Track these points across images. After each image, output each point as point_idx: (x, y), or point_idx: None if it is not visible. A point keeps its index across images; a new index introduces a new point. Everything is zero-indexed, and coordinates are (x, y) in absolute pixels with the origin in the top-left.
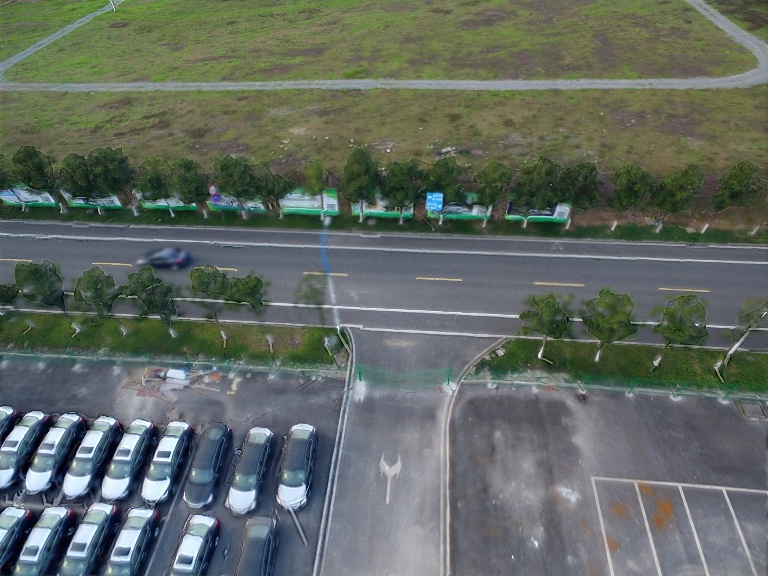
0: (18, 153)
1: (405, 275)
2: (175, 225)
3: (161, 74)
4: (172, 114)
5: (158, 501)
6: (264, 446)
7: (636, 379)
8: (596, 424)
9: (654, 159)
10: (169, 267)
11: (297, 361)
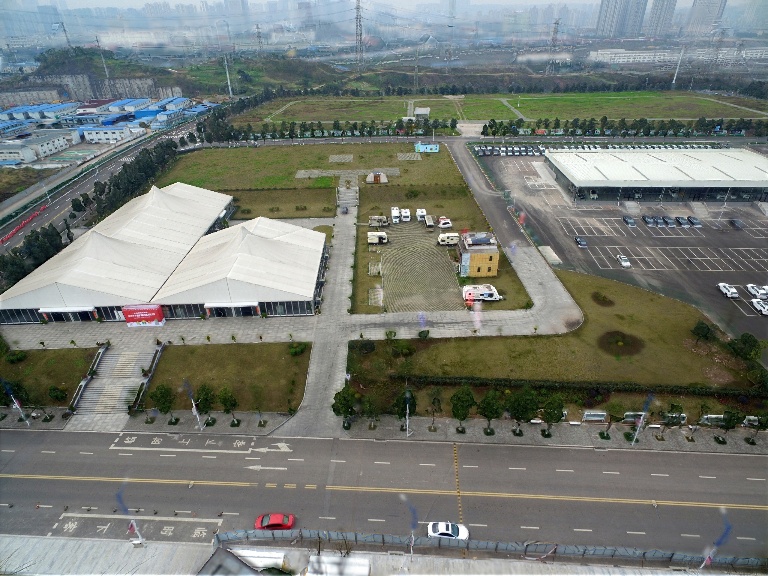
0: (623, 119)
1: (718, 139)
2: (653, 136)
3: None
4: None
5: None
6: None
7: None
8: None
9: None
10: None
11: (713, 144)
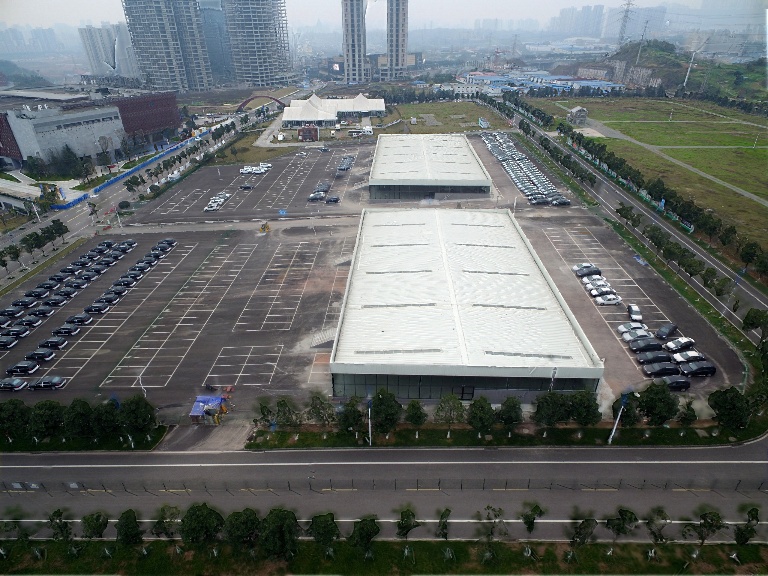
0: None
1: None
2: None
3: (701, 166)
4: (672, 172)
5: (544, 194)
6: (562, 198)
7: (622, 234)
8: (601, 228)
9: (761, 243)
10: (600, 186)
11: None
